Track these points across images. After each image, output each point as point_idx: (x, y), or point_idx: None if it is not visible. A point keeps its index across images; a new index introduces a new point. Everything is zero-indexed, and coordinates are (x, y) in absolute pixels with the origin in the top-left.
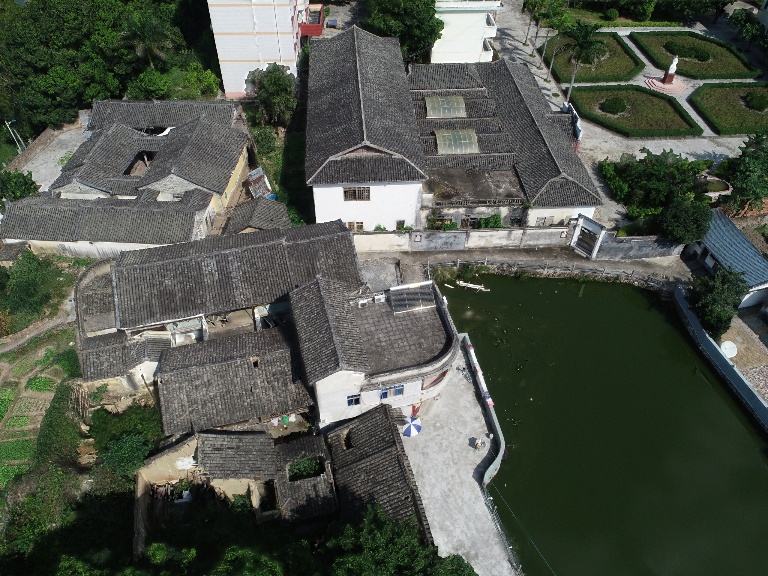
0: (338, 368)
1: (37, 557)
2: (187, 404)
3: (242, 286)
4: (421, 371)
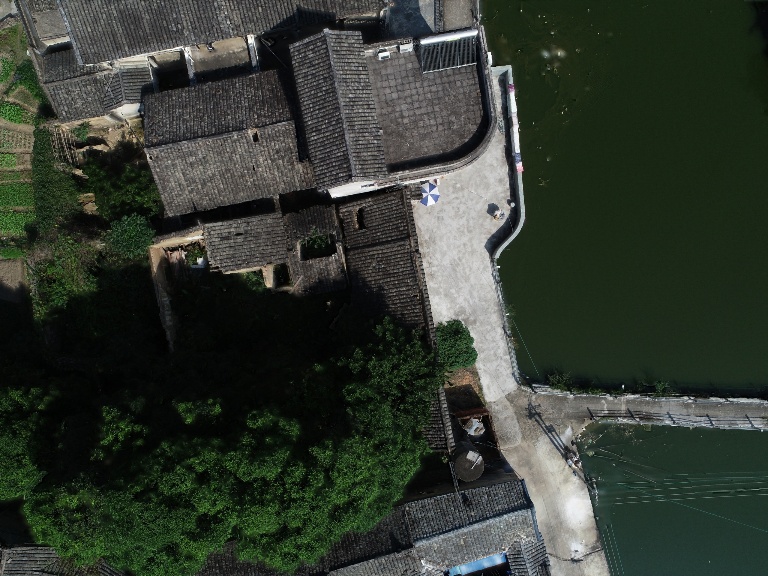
0: (351, 181)
1: (75, 309)
2: (185, 183)
3: (226, 6)
4: (446, 166)
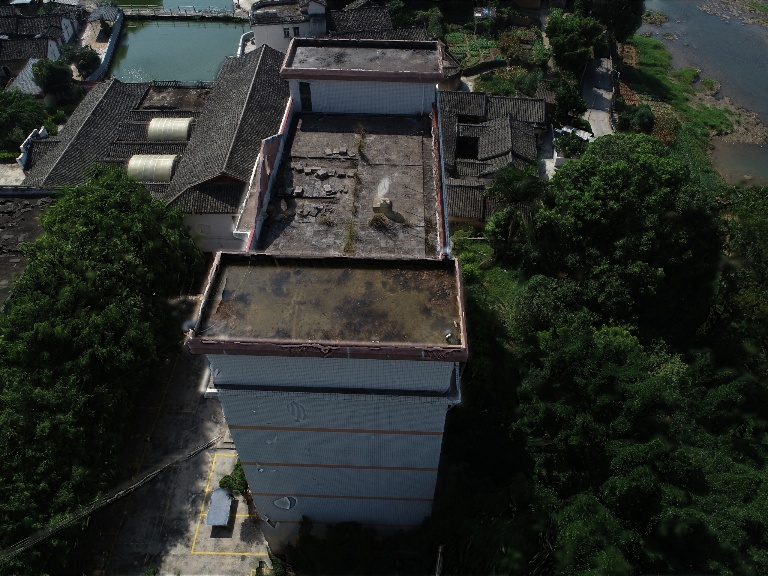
0: None
1: None
2: None
3: None
4: (273, 2)
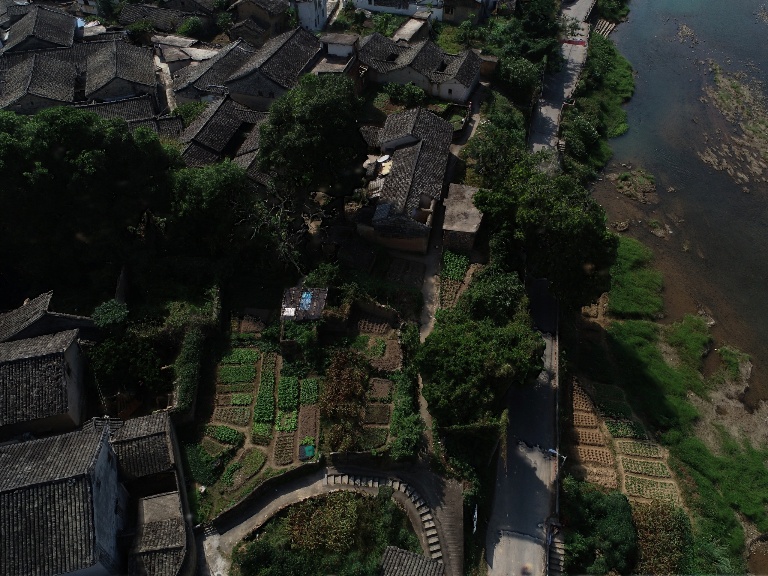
0: None
1: None
2: None
3: None
4: None
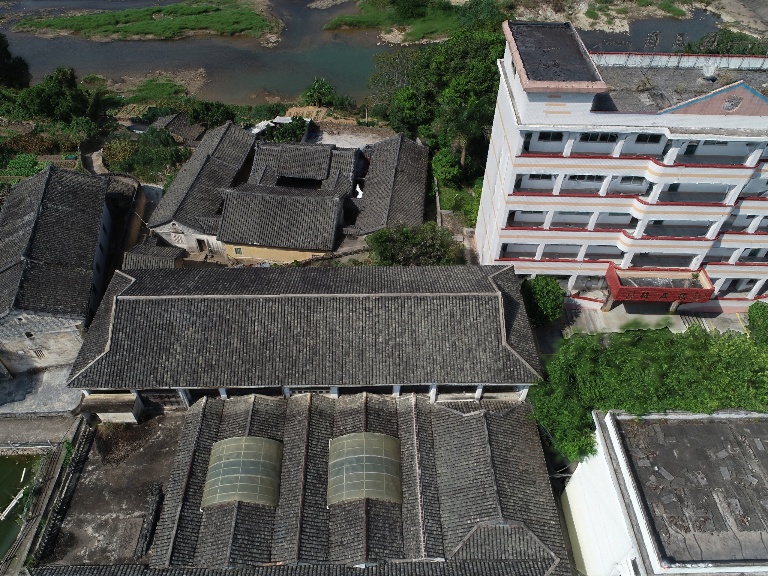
0: None
1: None
2: None
3: (3, 244)
4: None
